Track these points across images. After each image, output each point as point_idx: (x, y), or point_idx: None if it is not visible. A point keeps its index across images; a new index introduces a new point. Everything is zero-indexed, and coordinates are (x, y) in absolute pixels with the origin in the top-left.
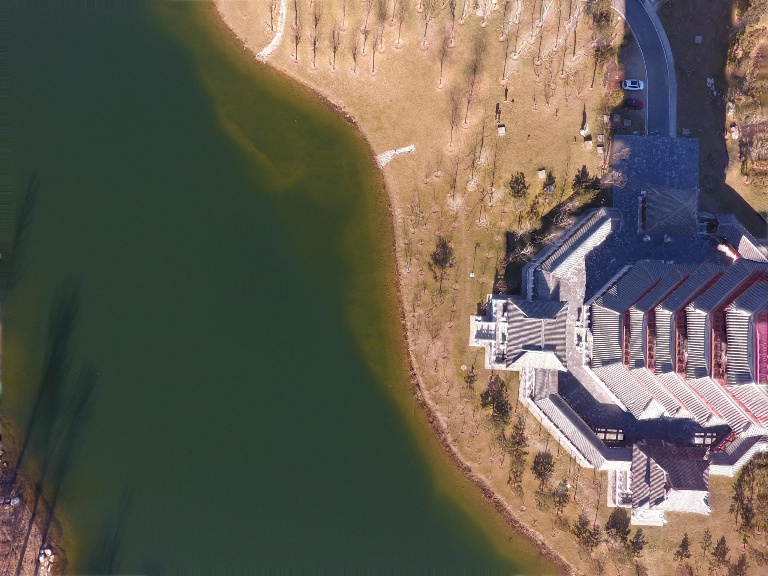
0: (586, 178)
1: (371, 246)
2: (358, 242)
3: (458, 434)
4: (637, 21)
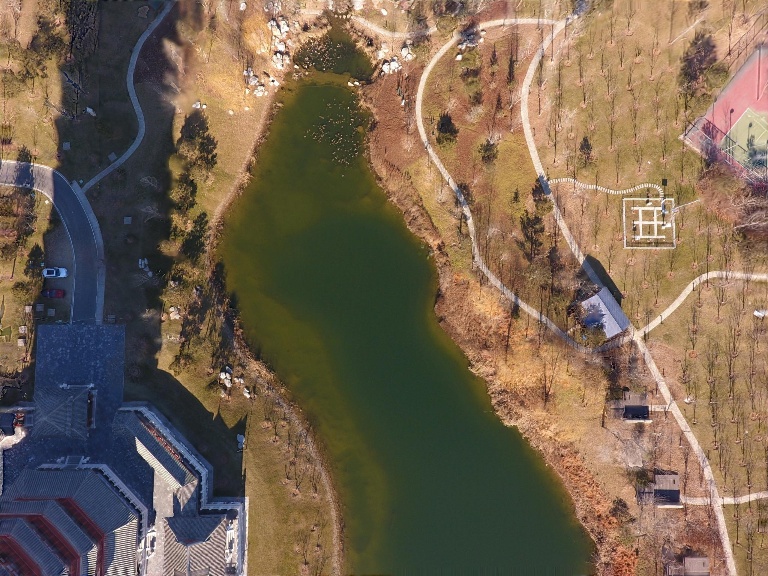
0: (5, 373)
1: None
2: None
3: None
4: (65, 204)
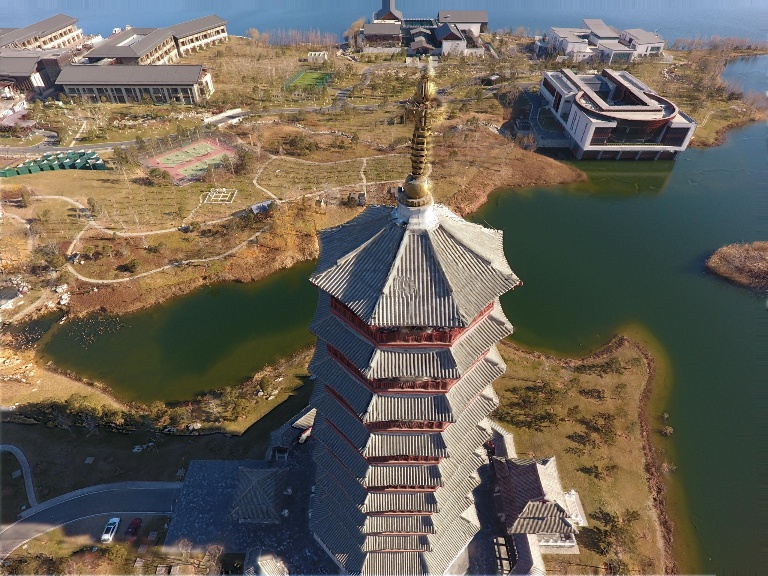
0: None
1: None
2: None
3: None
4: (39, 525)
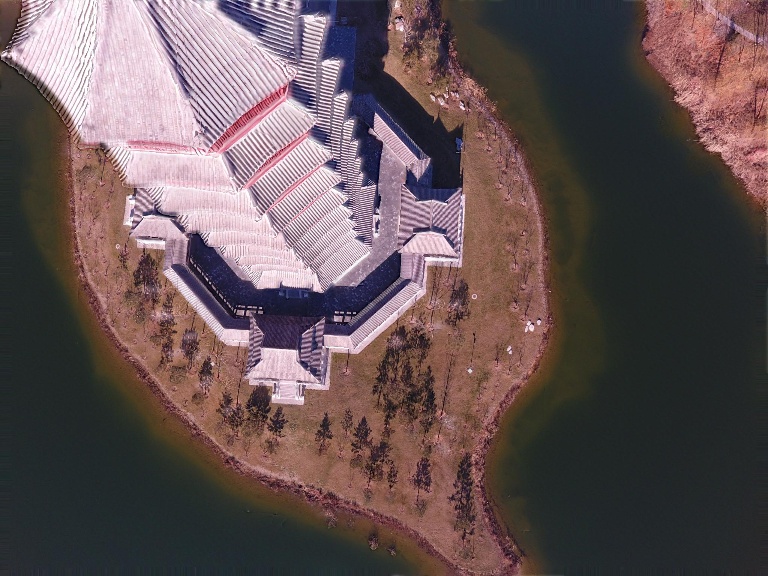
0: None
1: (50, 134)
2: (39, 130)
3: (116, 314)
4: None
